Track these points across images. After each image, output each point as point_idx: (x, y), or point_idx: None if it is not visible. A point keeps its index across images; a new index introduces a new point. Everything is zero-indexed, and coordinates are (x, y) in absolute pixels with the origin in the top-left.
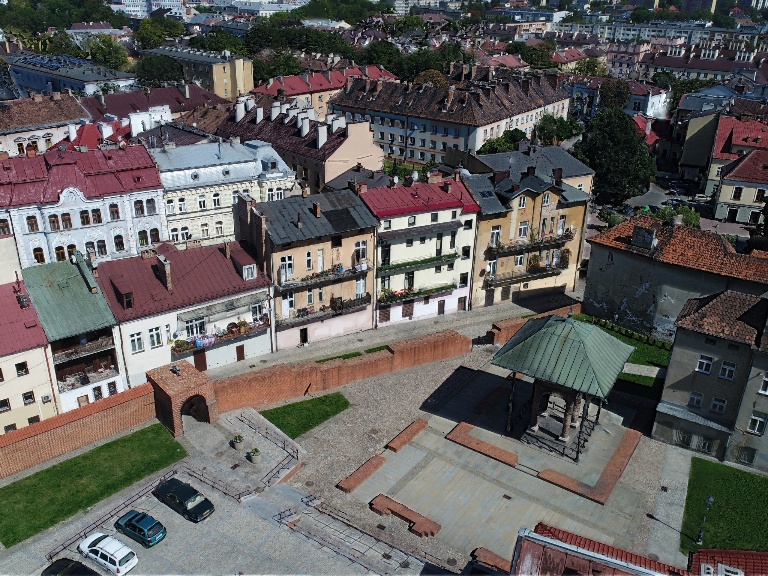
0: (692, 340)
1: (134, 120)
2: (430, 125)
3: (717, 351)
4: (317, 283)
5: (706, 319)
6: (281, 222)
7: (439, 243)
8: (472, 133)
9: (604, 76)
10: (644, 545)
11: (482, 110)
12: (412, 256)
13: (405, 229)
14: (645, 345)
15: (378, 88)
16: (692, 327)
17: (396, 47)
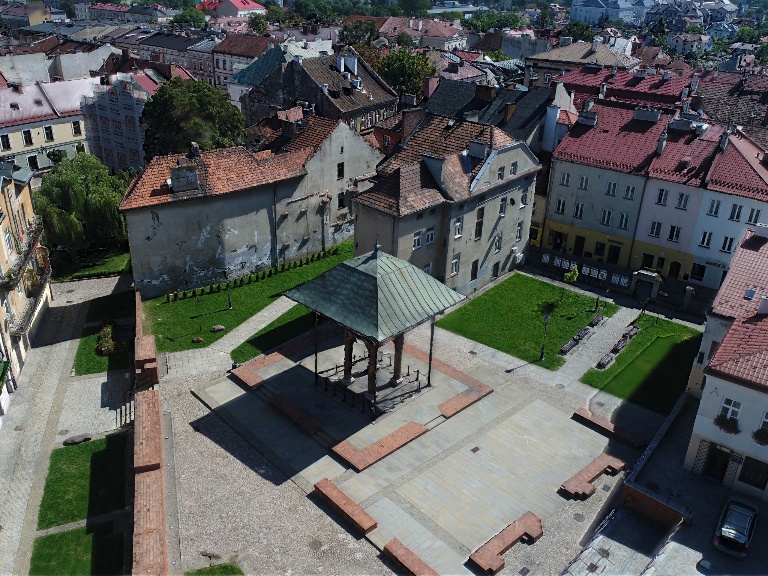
0: (409, 223)
1: None
2: None
3: (425, 222)
4: None
5: (409, 199)
6: None
7: None
8: None
9: None
10: (546, 386)
11: None
12: None
13: None
14: (239, 289)
15: None
16: (410, 211)
17: None
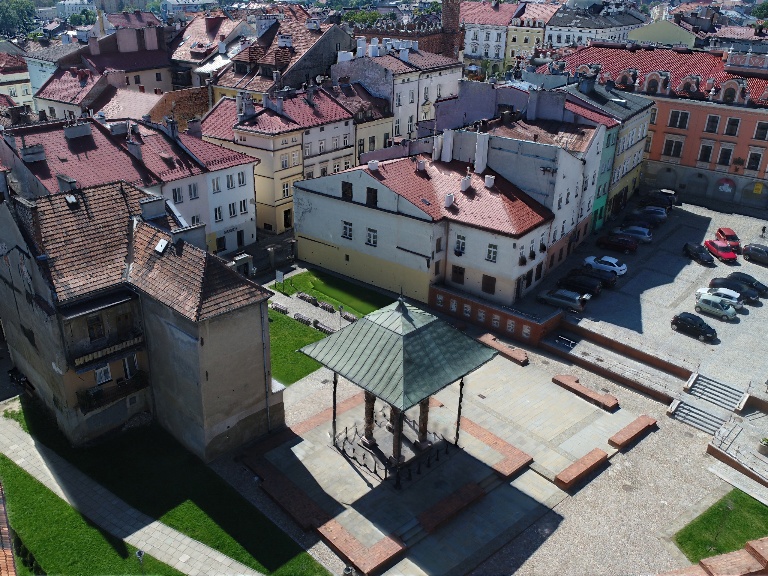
0: None
1: None
2: None
3: None
4: None
5: None
6: None
7: None
8: None
9: None
10: None
11: None
12: None
13: None
14: None
15: None
16: None
17: None
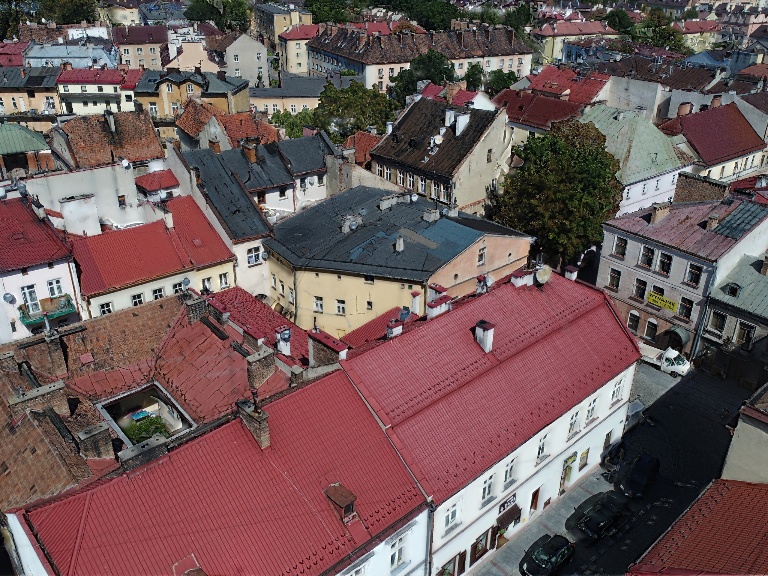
0: None
1: (71, 33)
2: (347, 63)
3: None
4: (19, 117)
5: None
6: (1, 78)
7: (110, 108)
8: (364, 70)
9: (675, 45)
10: None
11: (383, 52)
12: (85, 112)
13: (80, 94)
14: None
15: (333, 33)
16: (49, 132)
17: (456, 8)
